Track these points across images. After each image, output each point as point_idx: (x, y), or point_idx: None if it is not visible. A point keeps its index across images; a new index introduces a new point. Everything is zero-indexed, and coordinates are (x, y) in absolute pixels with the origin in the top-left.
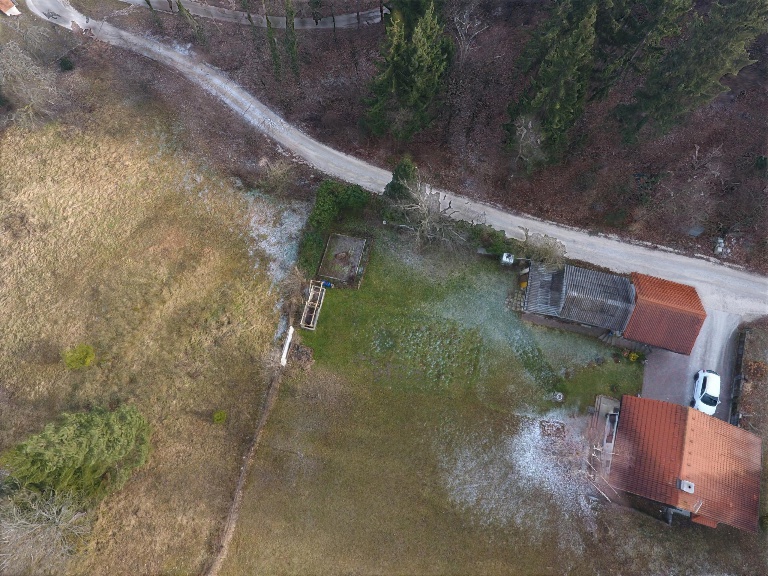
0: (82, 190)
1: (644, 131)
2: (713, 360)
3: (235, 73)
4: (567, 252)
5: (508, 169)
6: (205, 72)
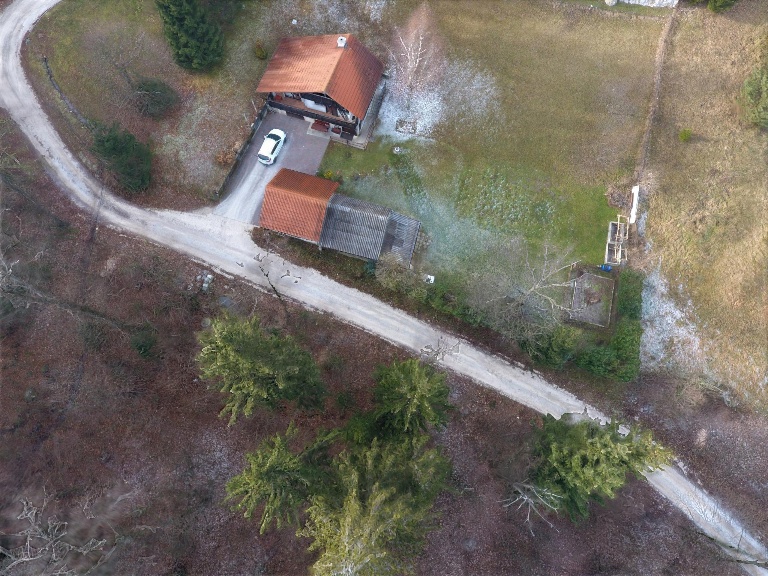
0: None
1: None
2: (253, 176)
3: None
4: None
5: None
6: None
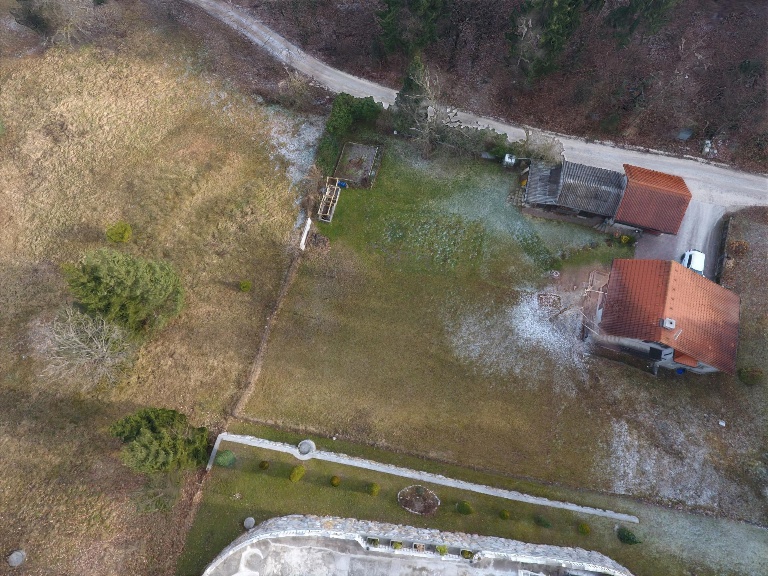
0: (116, 103)
1: (636, 35)
2: (699, 244)
3: (255, 10)
4: (565, 157)
5: (511, 88)
6: (227, 9)
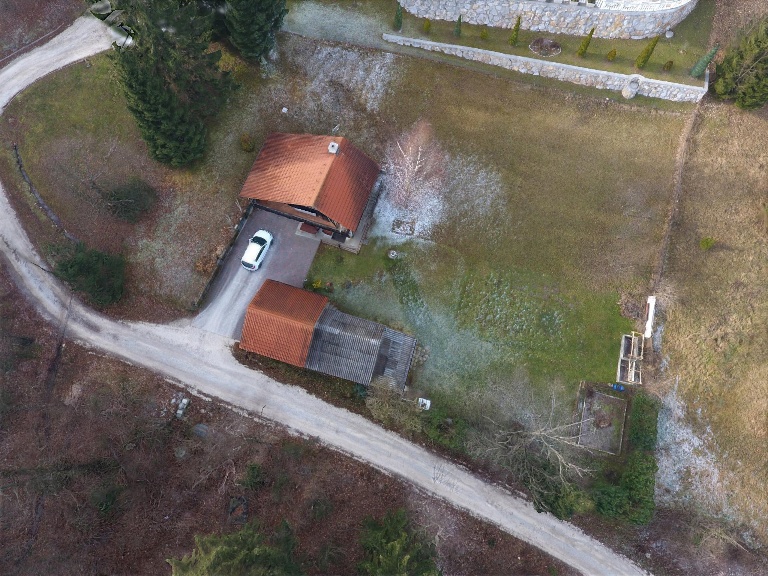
0: None
1: None
2: (236, 282)
3: None
4: None
5: None
6: None
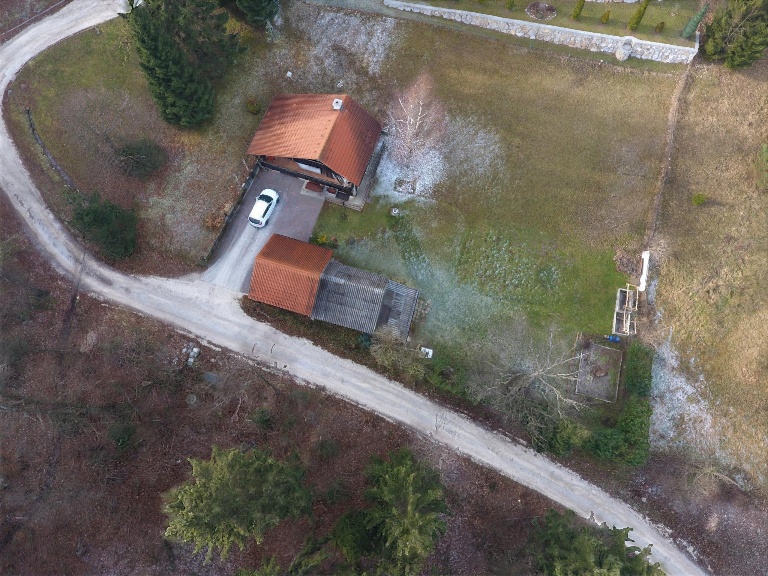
0: None
1: None
2: (244, 239)
3: None
4: None
5: None
6: None
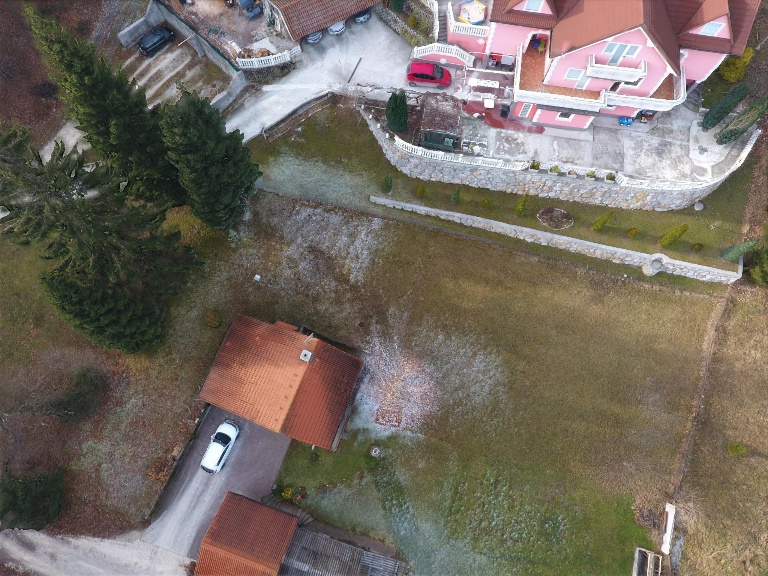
0: None
1: None
2: (195, 485)
3: None
4: None
5: None
6: None
